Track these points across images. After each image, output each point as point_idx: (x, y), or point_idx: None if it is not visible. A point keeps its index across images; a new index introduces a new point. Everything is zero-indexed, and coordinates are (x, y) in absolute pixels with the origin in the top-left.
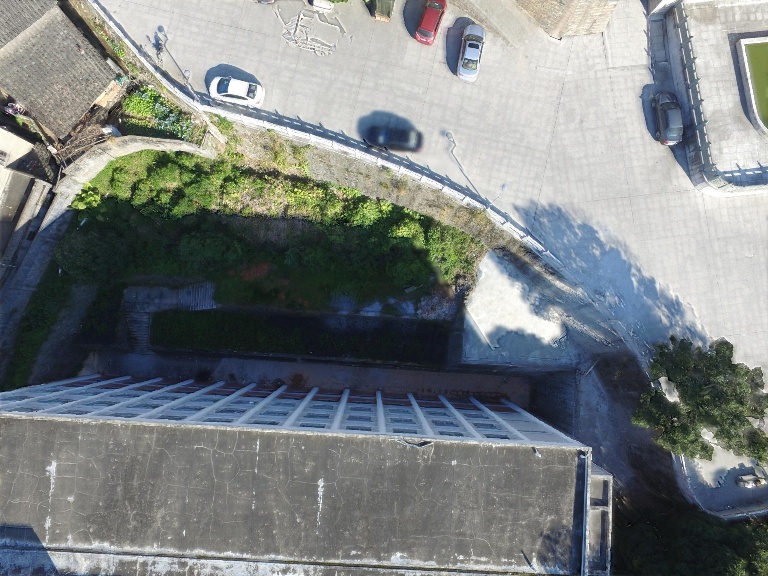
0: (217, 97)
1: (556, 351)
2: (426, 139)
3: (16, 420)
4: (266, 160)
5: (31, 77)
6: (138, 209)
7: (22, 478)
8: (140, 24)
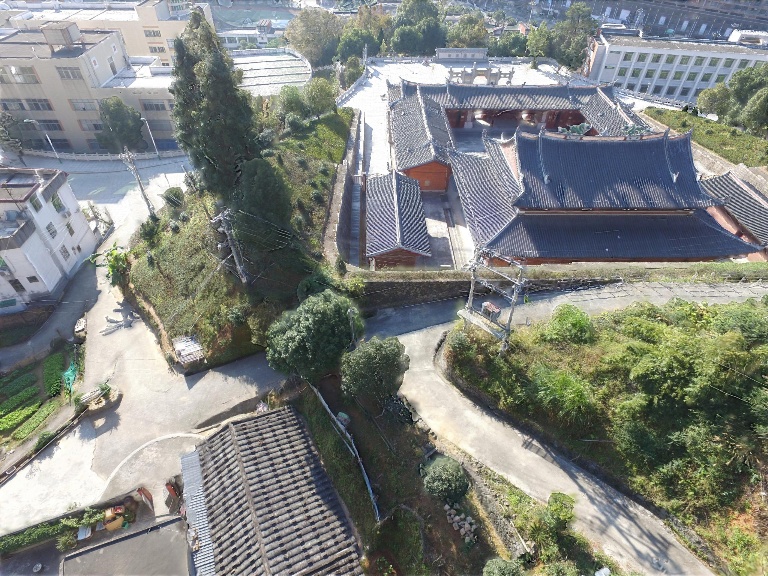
0: None
1: None
2: None
3: None
4: None
5: None
6: None
7: (762, 52)
8: None
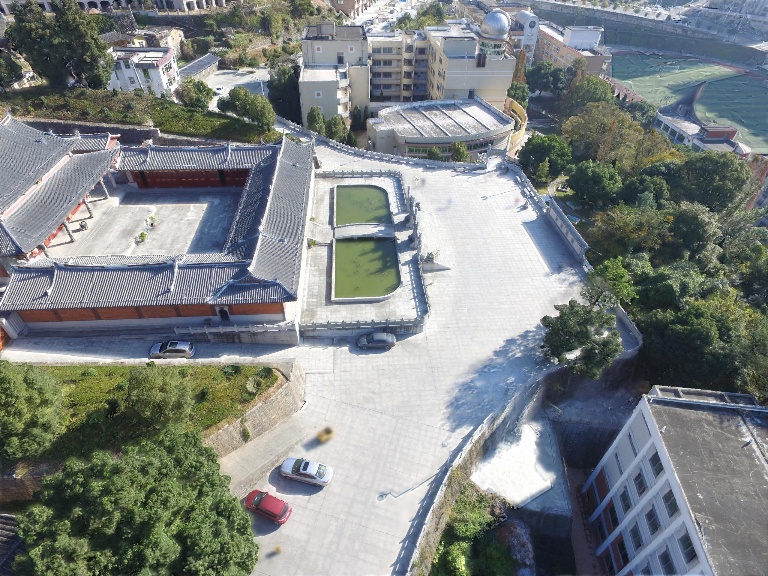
0: None
1: (543, 434)
2: (383, 521)
3: None
4: None
5: None
6: None
7: None
8: None
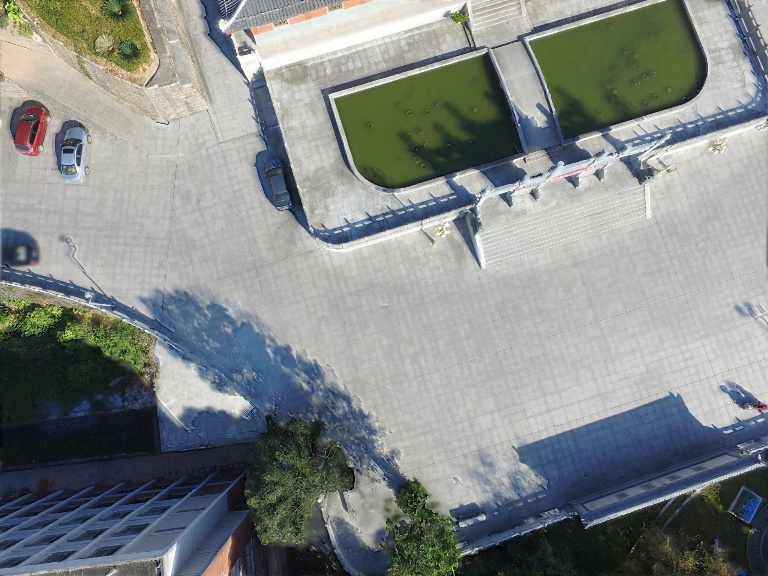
0: None
1: (251, 423)
2: (46, 248)
3: None
4: None
5: None
6: None
7: None
8: None
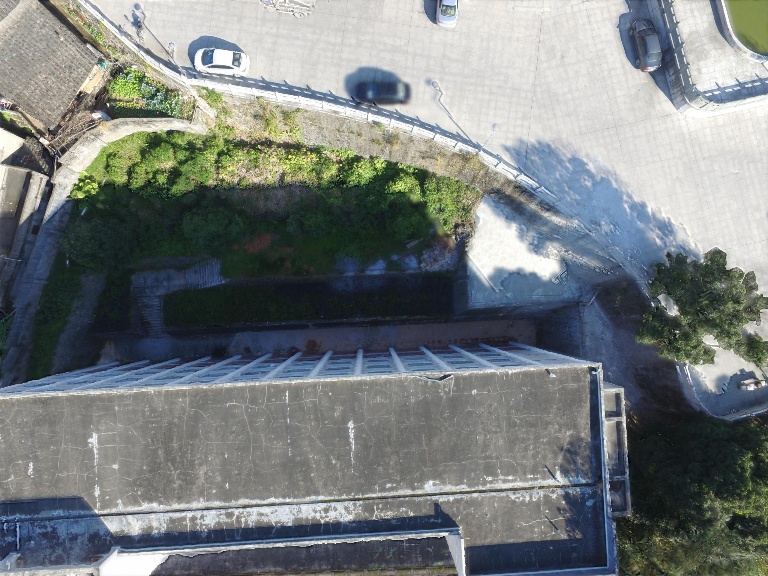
0: (203, 69)
1: (558, 287)
2: (413, 90)
3: (53, 398)
4: (257, 130)
5: (14, 69)
6: (136, 193)
7: (66, 452)
8: (116, 4)
